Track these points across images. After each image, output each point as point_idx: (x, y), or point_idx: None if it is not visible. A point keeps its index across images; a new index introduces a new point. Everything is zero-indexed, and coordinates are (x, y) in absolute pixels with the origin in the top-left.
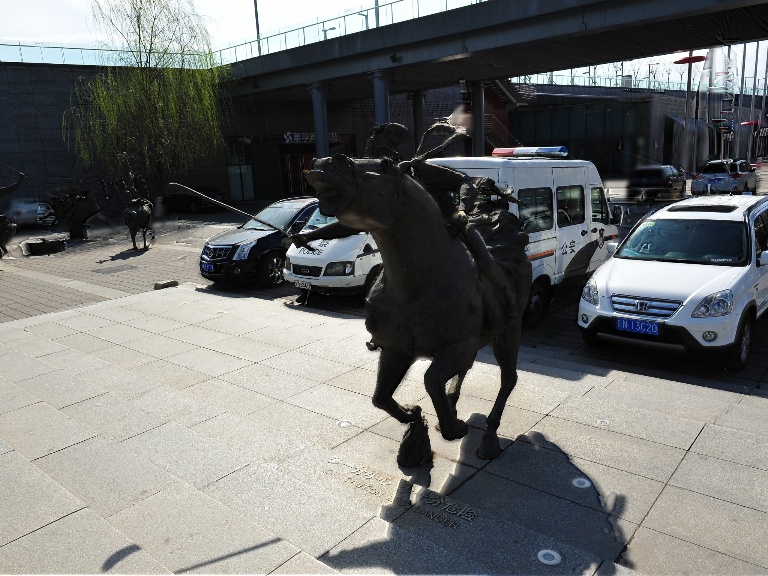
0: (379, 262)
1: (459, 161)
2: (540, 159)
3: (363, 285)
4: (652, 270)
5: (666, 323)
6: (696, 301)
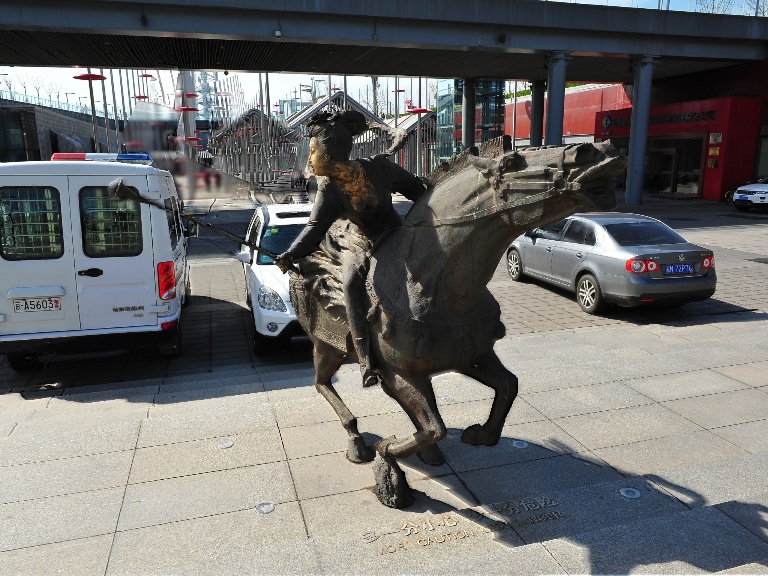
0: None
1: (82, 165)
2: None
3: None
4: None
5: None
6: None
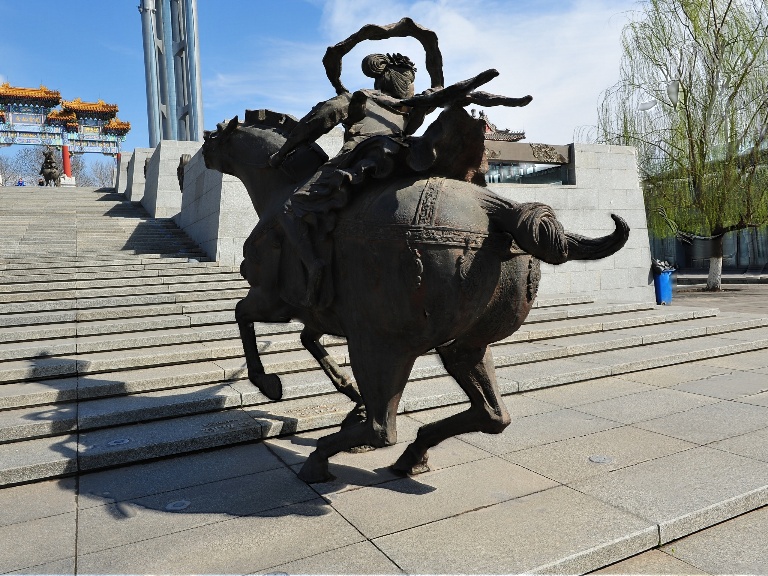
0: None
1: None
2: None
3: None
4: None
5: None
6: None
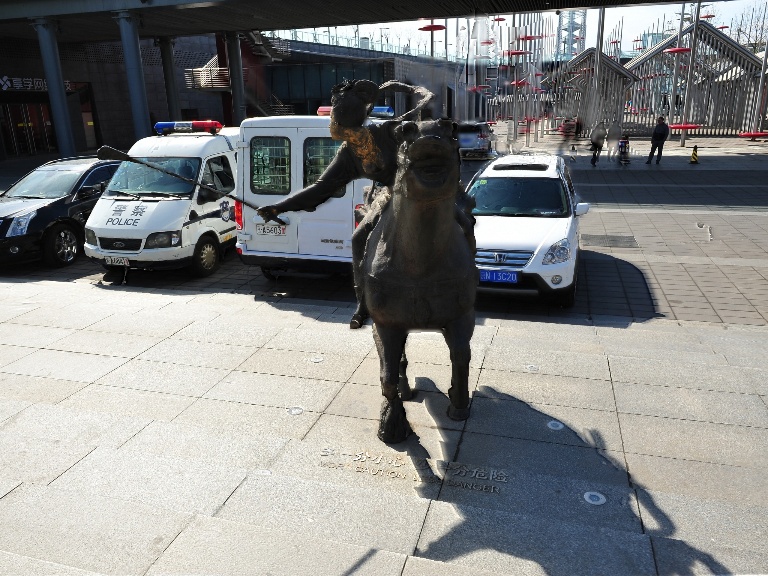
0: (206, 230)
1: (308, 120)
2: (376, 119)
3: (192, 256)
4: (498, 224)
5: (523, 272)
6: (545, 250)
